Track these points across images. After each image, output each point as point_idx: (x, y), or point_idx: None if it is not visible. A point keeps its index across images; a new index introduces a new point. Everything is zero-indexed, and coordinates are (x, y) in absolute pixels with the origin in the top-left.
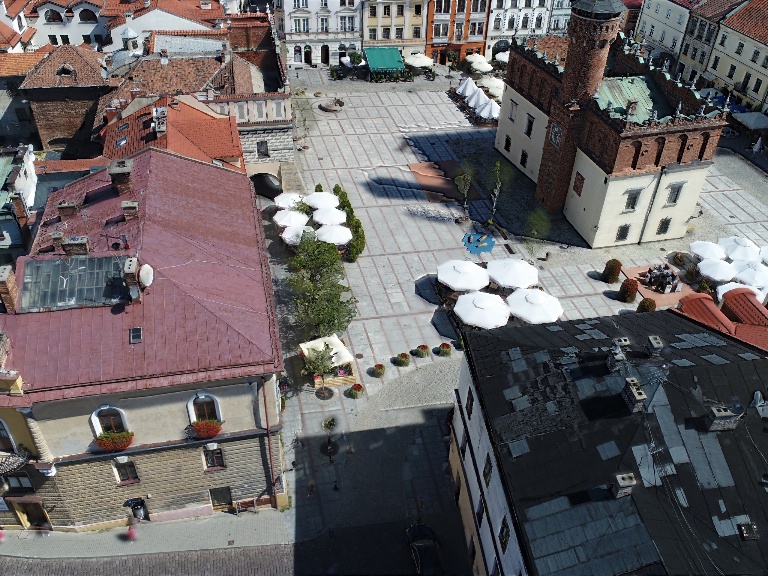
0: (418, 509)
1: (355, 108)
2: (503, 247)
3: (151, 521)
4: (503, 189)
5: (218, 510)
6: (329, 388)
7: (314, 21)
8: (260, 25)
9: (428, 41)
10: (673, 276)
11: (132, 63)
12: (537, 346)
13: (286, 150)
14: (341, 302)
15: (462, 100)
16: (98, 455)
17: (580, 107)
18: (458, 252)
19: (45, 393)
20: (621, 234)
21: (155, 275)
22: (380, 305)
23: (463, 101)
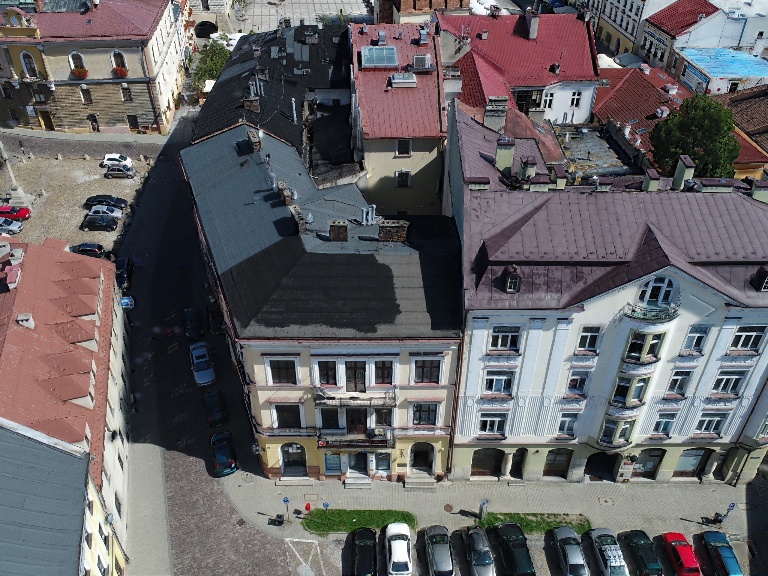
0: None
1: (293, 4)
2: None
3: (100, 132)
4: None
5: (133, 132)
6: None
7: None
8: None
9: None
10: None
11: None
12: None
13: (220, 6)
14: None
15: None
16: (73, 81)
17: None
18: None
19: (49, 39)
20: None
21: (102, 3)
22: None
23: None
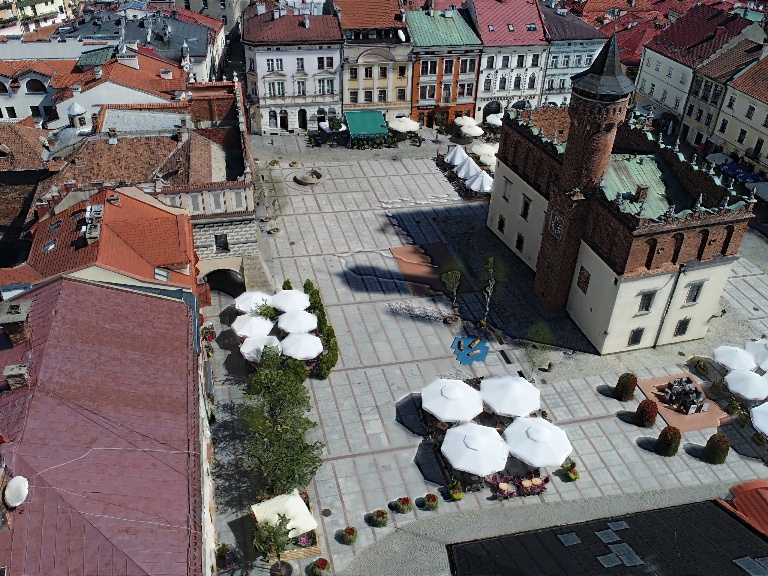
0: None
1: (334, 180)
2: (498, 354)
3: None
4: (497, 278)
5: None
6: (287, 562)
7: (290, 84)
8: (224, 97)
9: (414, 104)
10: (697, 392)
11: (76, 144)
12: None
13: (249, 243)
14: (304, 446)
15: (451, 169)
16: None
17: (584, 196)
18: (446, 362)
19: None
20: (634, 338)
21: (34, 482)
22: (354, 438)
23: (452, 171)
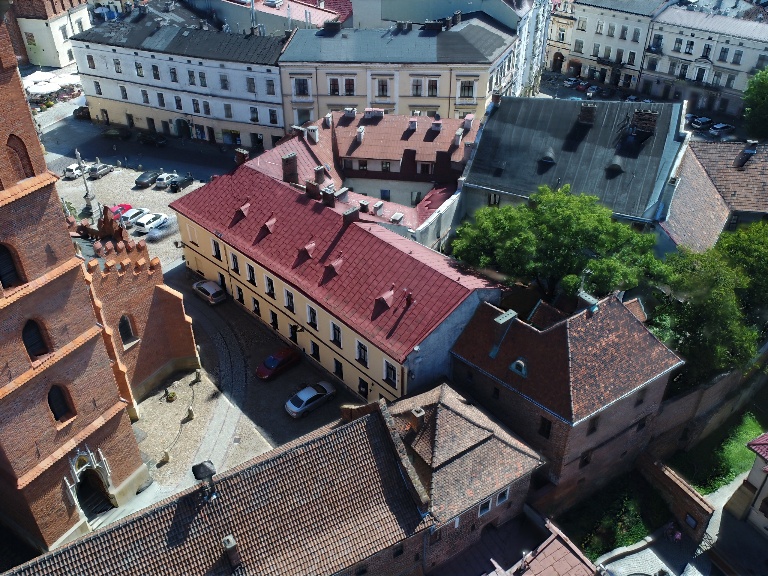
0: (97, 133)
1: None
2: None
3: None
4: None
5: None
6: None
7: None
8: None
9: None
10: None
11: None
12: None
13: None
14: None
15: None
16: None
17: None
18: None
19: None
20: (70, 56)
21: None
22: None
23: None
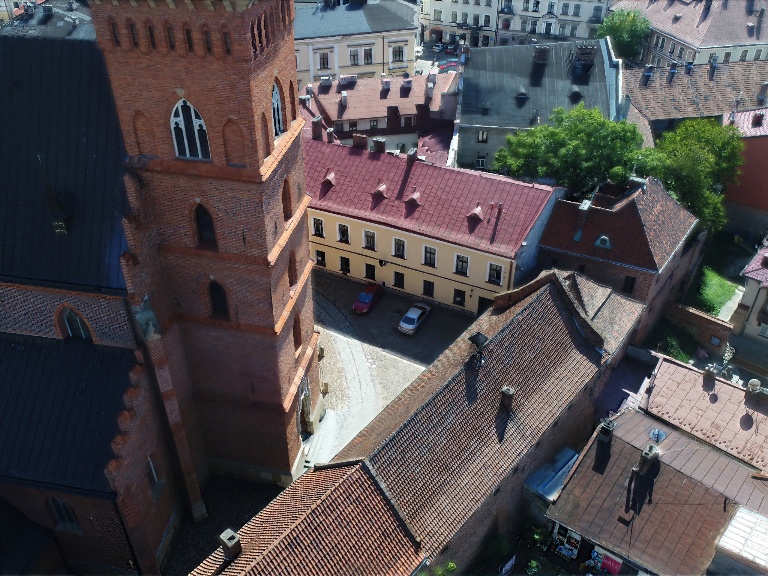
0: None
1: None
2: None
3: None
4: None
5: None
6: None
7: None
8: None
9: None
10: None
11: None
12: (1, 29)
13: None
14: None
15: None
16: None
17: None
18: None
19: None
20: None
21: None
22: None
23: None
